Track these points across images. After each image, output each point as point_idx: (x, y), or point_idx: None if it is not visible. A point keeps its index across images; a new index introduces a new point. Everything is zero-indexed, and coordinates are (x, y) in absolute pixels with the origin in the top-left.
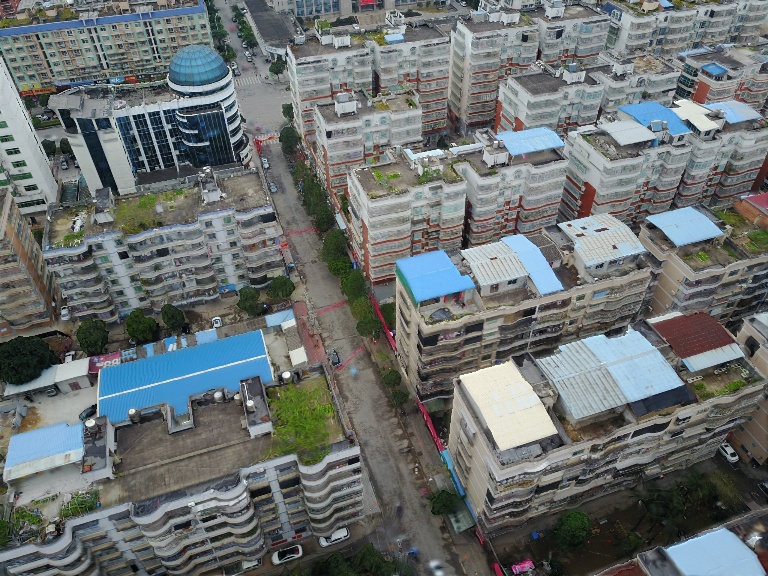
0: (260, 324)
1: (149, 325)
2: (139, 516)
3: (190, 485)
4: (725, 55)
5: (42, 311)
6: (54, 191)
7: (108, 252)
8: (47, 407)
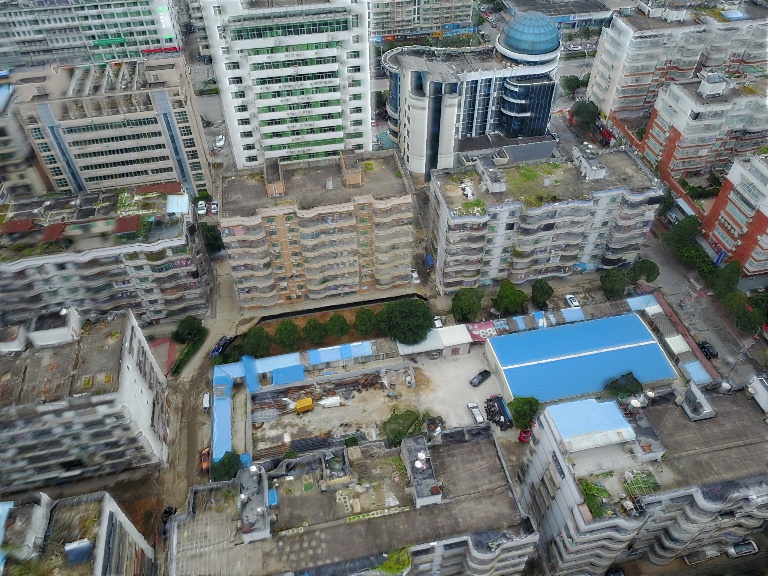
0: (624, 307)
1: (522, 298)
2: (716, 504)
3: (743, 477)
4: None
5: (408, 273)
6: None
7: (498, 222)
8: (432, 369)
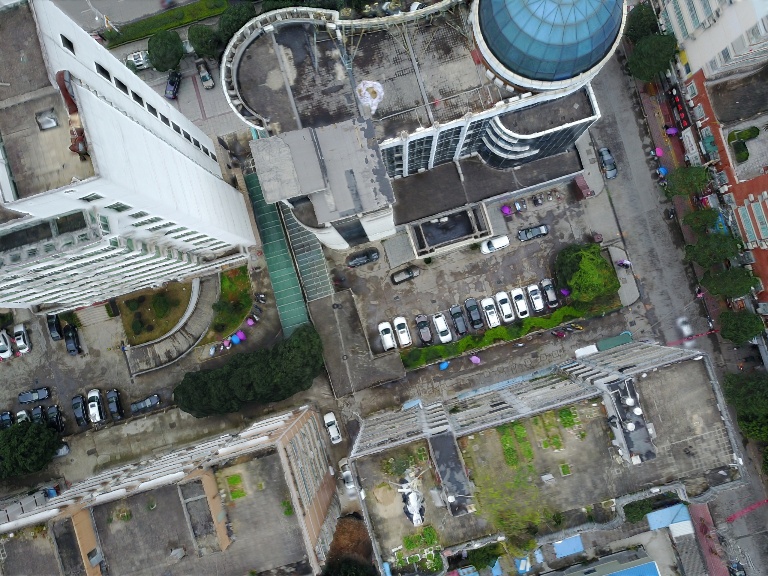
0: (640, 527)
1: None
2: None
3: None
4: None
5: None
6: (247, 221)
7: None
8: None
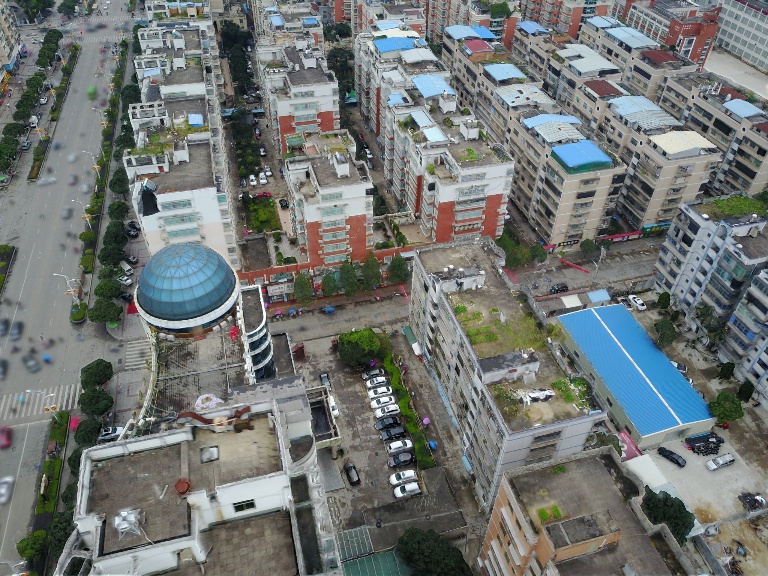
0: None
1: None
2: None
3: None
4: (289, 13)
5: None
6: None
7: None
8: None
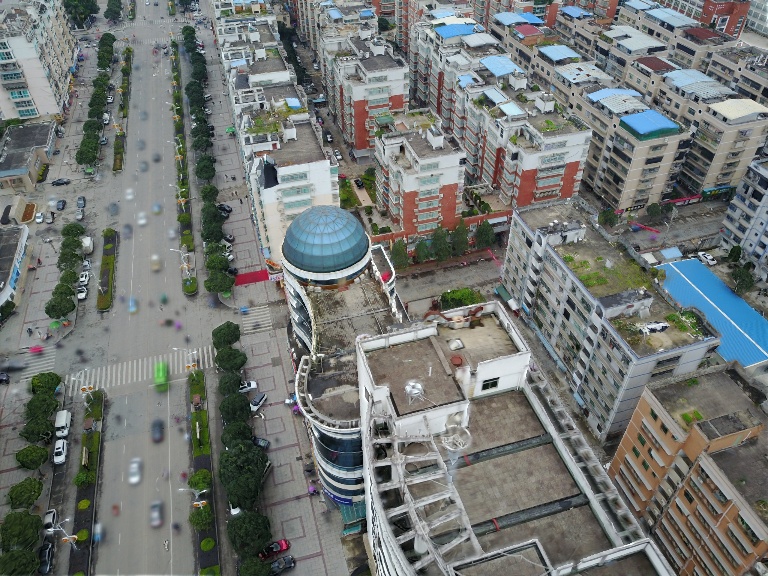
0: None
1: None
2: None
3: None
4: (345, 7)
5: None
6: None
7: None
8: None
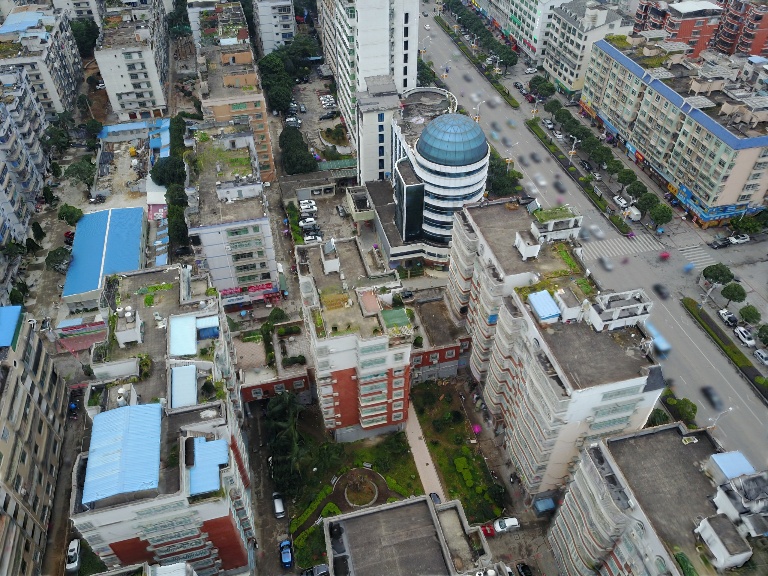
0: None
1: None
2: None
3: None
4: None
5: None
6: None
7: None
8: (144, 199)
